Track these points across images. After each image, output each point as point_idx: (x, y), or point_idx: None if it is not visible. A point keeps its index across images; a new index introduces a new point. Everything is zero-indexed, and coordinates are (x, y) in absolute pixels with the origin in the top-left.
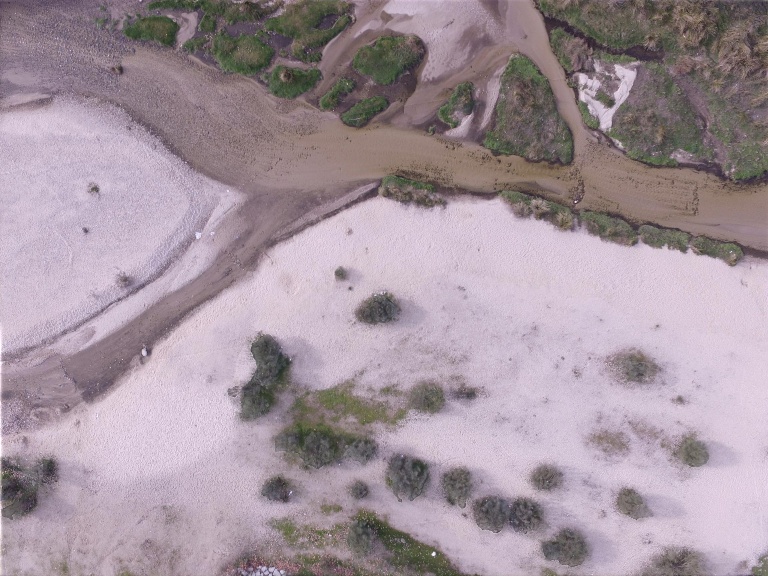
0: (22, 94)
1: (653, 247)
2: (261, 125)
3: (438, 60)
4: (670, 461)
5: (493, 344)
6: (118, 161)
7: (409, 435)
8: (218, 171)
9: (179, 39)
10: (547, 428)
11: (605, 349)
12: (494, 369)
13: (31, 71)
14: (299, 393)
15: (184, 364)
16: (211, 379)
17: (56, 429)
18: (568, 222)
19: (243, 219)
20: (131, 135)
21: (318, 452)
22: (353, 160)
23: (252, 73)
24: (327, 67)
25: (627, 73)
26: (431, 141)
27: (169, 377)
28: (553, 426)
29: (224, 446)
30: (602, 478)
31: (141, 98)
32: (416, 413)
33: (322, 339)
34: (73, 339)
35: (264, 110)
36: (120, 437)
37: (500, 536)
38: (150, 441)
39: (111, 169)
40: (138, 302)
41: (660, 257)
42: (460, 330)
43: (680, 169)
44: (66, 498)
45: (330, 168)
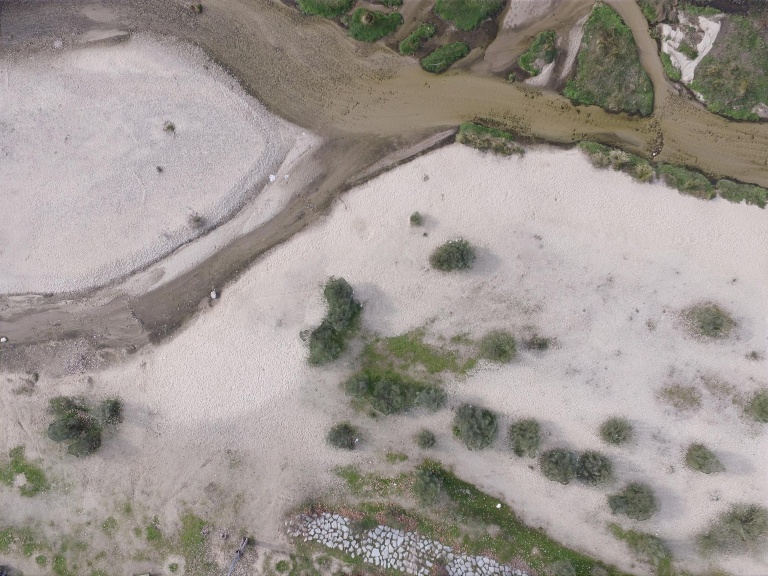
0: (99, 30)
1: (731, 202)
2: (339, 68)
3: (521, 7)
4: (741, 418)
5: (567, 295)
6: (195, 100)
7: (478, 385)
8: (294, 113)
9: None
10: (618, 381)
11: (680, 302)
12: (567, 320)
13: (109, 7)
14: (369, 340)
15: (254, 307)
16: (281, 323)
17: (122, 370)
18: (648, 173)
19: (318, 163)
20: (208, 74)
21: (389, 398)
22: (431, 106)
23: (332, 15)
24: (408, 11)
25: (711, 25)
26: (510, 89)
27: (238, 320)
28: (624, 380)
29: (291, 391)
30: (672, 433)
31: (219, 37)
32: (486, 363)
33: (394, 285)
34: (142, 279)
35: (343, 53)
36: (187, 379)
37: (566, 490)
38: (217, 384)
39: (187, 108)
40: (209, 244)
41: (738, 212)
42: (535, 280)
43: (760, 124)
44: (130, 439)
45: (407, 113)
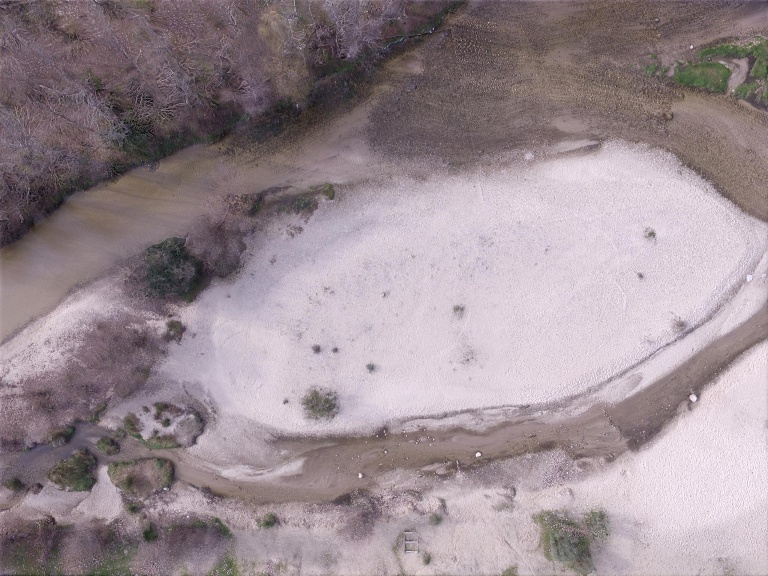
0: (570, 141)
1: None
2: None
3: None
4: None
5: None
6: (674, 205)
7: None
8: None
9: (730, 84)
10: None
11: None
12: None
13: (579, 118)
14: None
15: (739, 409)
16: None
17: (602, 480)
18: None
19: None
20: (682, 179)
21: None
22: None
23: None
24: None
25: None
26: None
27: (723, 423)
28: None
29: None
30: None
31: (691, 142)
32: None
33: None
34: (619, 386)
35: None
36: (673, 487)
37: None
38: (705, 490)
39: (667, 213)
40: (686, 347)
41: None
42: None
43: None
44: (619, 552)
45: None
